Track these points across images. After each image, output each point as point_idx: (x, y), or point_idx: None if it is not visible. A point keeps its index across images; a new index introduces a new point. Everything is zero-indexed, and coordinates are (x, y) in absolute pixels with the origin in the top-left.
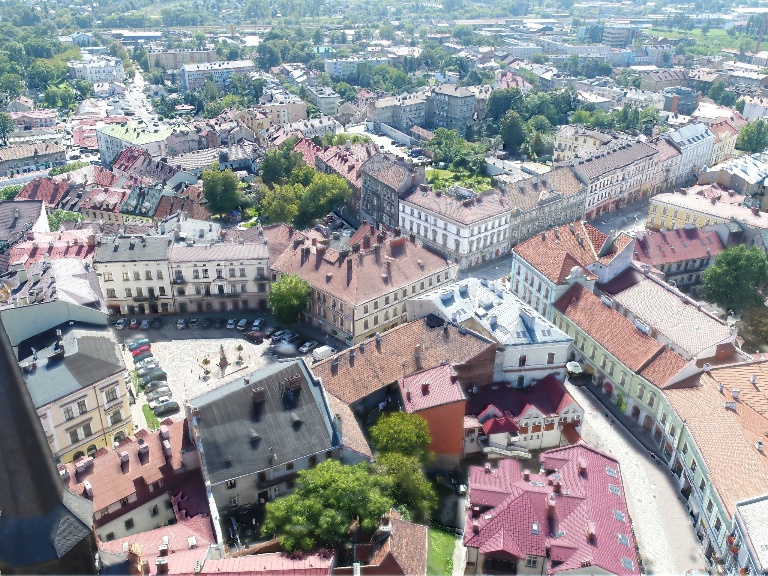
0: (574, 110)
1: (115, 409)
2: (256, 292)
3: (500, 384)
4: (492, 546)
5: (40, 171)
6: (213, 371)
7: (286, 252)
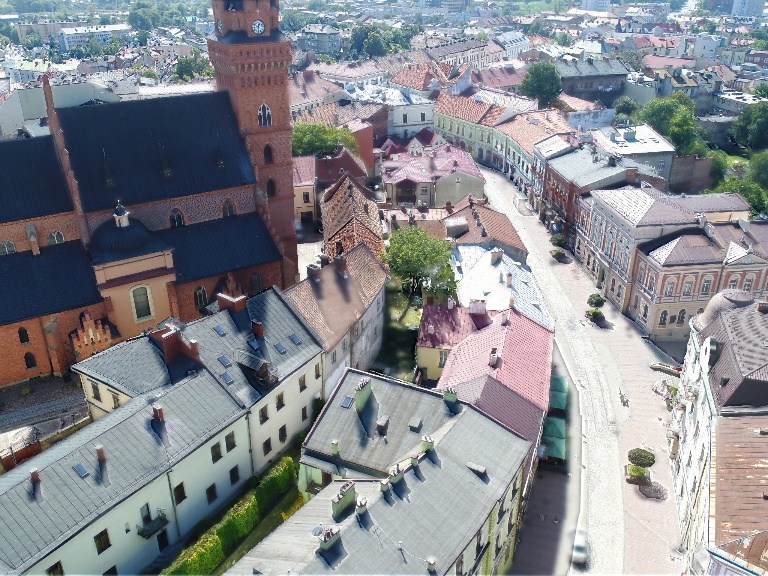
0: None
1: None
2: None
3: (393, 136)
4: (400, 180)
5: None
6: None
7: None
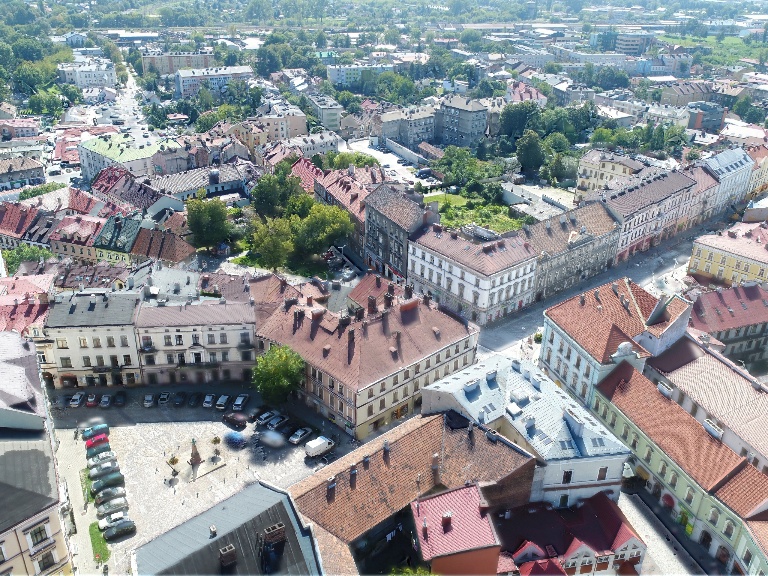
0: (594, 127)
1: (45, 552)
2: (240, 361)
3: (538, 505)
4: None
5: (13, 190)
6: (182, 471)
7: (276, 314)
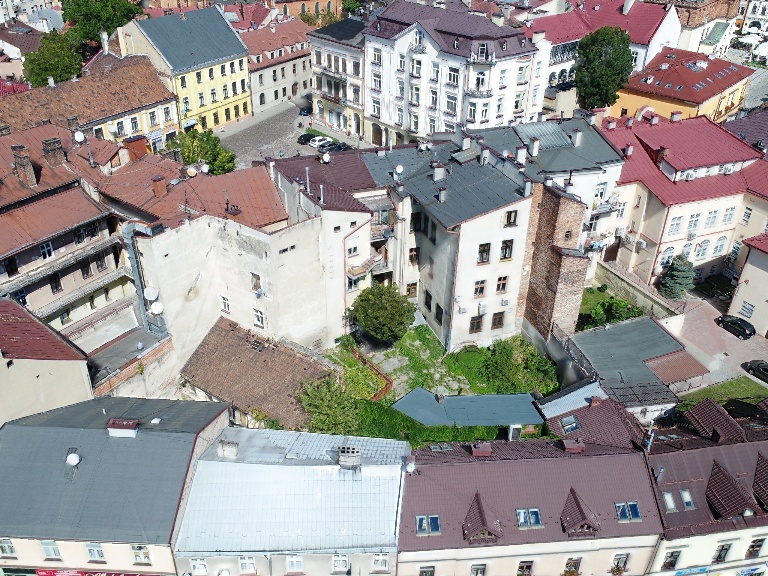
0: None
1: None
2: None
3: None
4: None
5: None
6: None
7: None
